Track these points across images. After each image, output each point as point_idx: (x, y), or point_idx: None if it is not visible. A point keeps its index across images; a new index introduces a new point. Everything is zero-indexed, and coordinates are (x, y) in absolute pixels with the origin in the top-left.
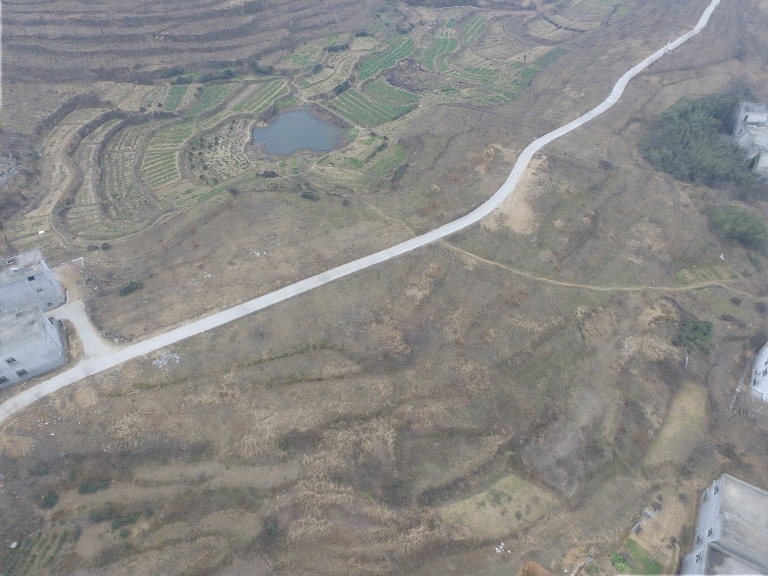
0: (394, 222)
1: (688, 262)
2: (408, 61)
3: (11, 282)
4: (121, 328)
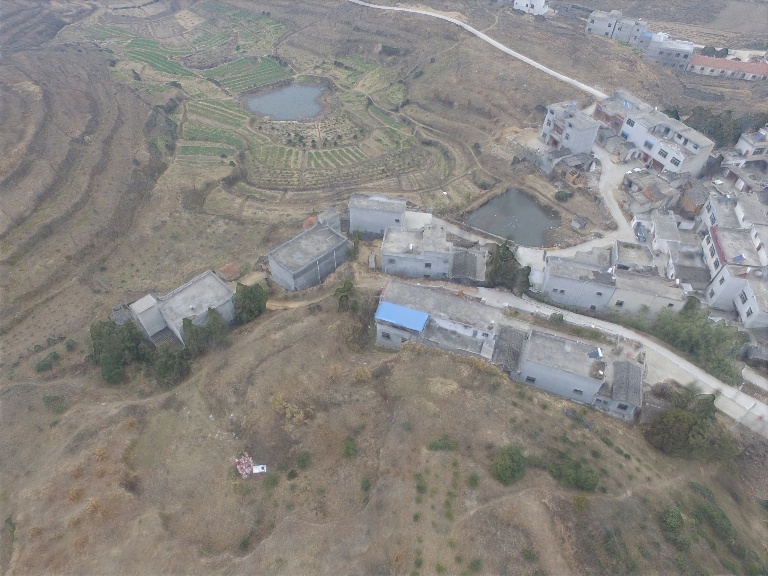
0: None
1: None
2: None
3: None
4: None
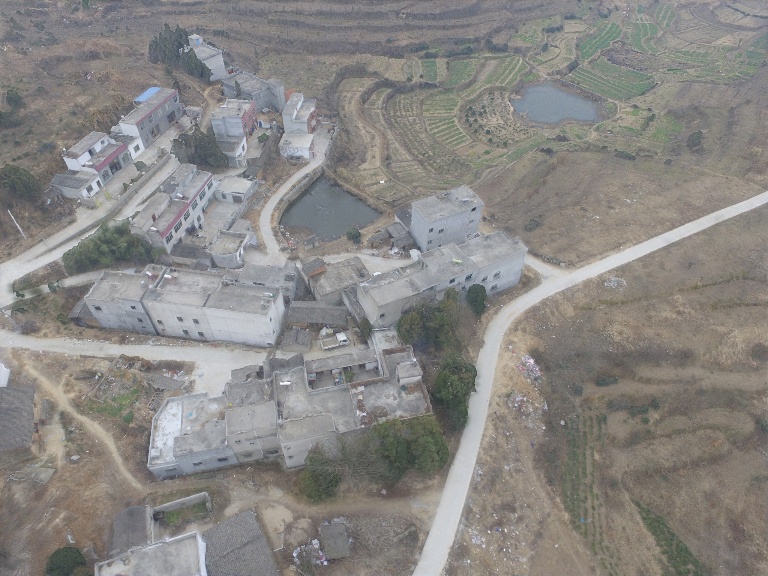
0: (734, 178)
1: None
2: (621, 43)
3: (462, 211)
4: (555, 255)
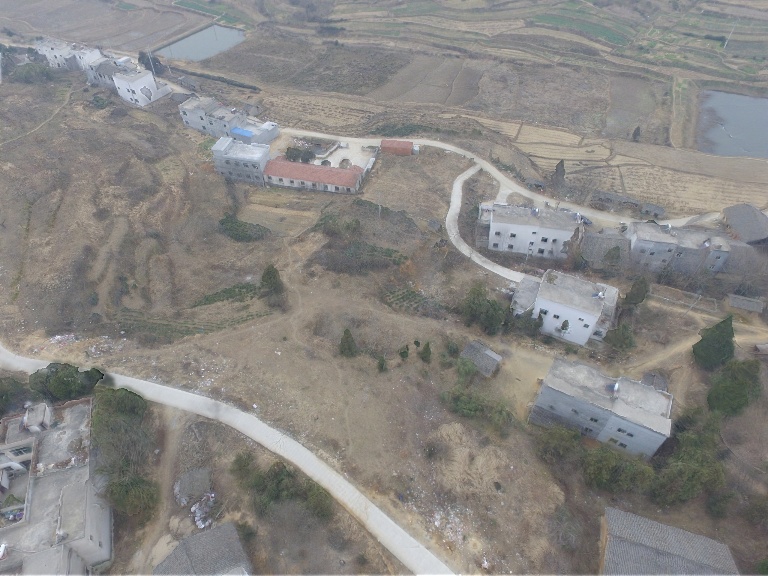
0: None
1: (49, 95)
2: None
3: None
4: None
